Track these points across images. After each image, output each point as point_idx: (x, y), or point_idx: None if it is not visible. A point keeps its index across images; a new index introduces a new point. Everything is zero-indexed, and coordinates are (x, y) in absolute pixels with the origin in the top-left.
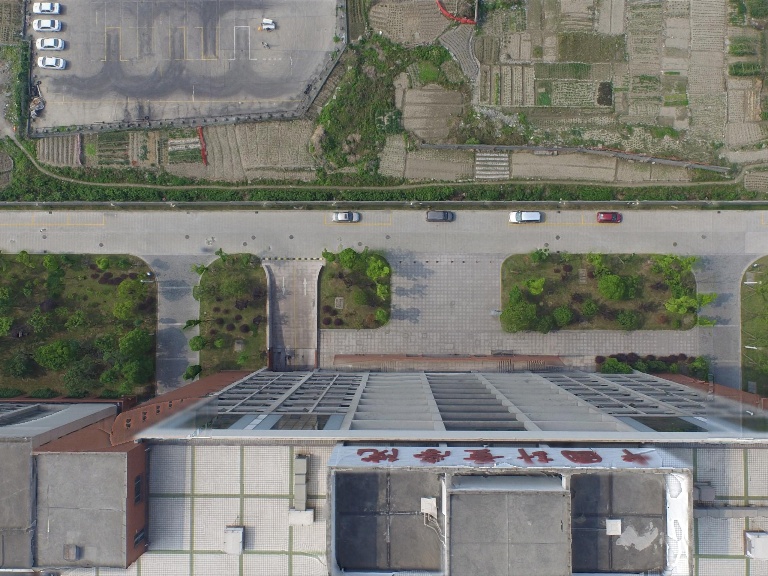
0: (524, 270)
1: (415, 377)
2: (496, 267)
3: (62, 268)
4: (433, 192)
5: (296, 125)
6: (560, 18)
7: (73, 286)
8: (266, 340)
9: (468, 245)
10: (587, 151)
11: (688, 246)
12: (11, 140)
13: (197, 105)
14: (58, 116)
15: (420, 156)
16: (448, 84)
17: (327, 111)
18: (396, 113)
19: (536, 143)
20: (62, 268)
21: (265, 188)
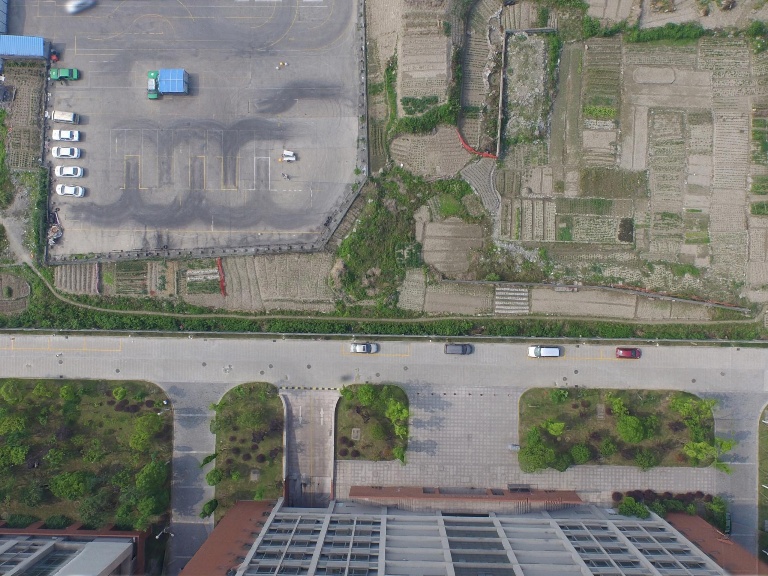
0: (542, 405)
1: (434, 529)
2: (514, 400)
3: (78, 394)
4: (452, 326)
5: (316, 258)
6: (582, 153)
7: (89, 412)
8: (282, 471)
9: (486, 378)
10: (607, 289)
11: (707, 383)
12: (28, 267)
13: (216, 235)
14: (76, 243)
15: (440, 290)
16: (469, 218)
17: (347, 245)
18: (416, 247)
19: (556, 278)
20: (78, 394)
21: (283, 318)
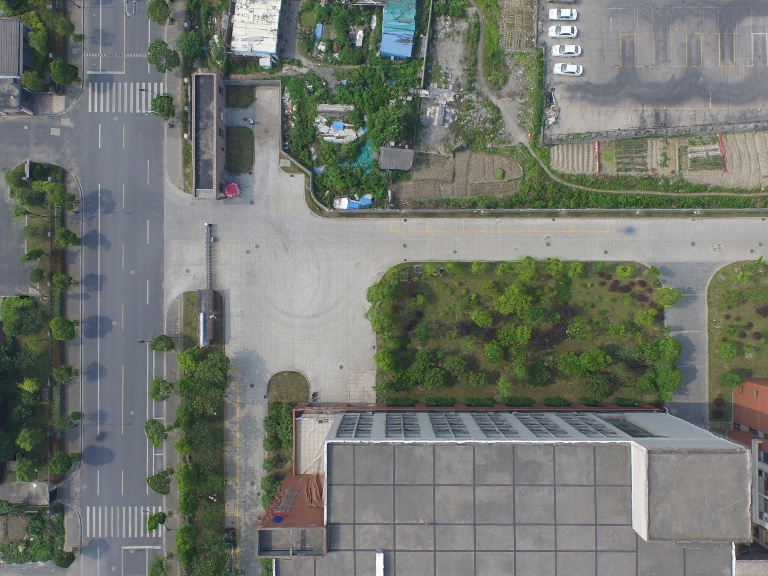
0: None
1: None
2: None
3: (569, 276)
4: None
5: None
6: None
7: (580, 294)
8: None
9: None
10: None
11: None
12: (526, 147)
13: (714, 112)
14: (572, 123)
15: None
16: None
17: None
18: None
19: None
20: (569, 276)
21: None
